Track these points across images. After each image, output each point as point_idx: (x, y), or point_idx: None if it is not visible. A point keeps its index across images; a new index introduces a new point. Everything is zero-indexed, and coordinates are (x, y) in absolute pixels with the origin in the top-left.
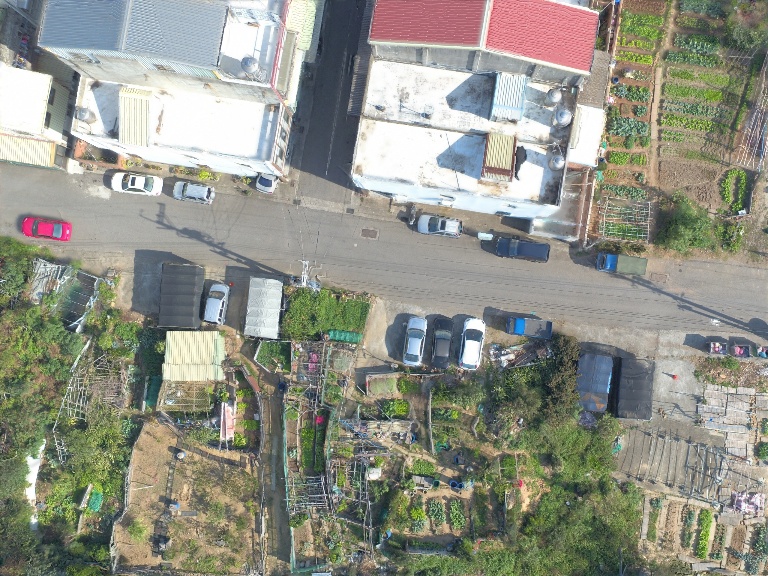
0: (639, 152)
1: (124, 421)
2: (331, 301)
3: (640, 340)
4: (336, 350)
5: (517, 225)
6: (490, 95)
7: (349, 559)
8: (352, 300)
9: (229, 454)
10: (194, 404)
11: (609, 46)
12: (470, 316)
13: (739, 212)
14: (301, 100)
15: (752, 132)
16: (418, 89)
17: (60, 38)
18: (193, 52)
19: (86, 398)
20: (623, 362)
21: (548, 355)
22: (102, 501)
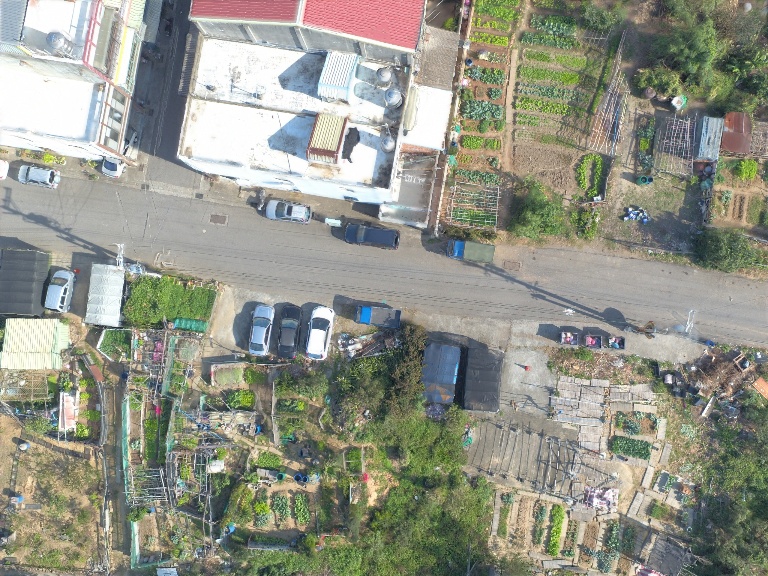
0: (494, 136)
1: None
2: (178, 288)
3: (492, 330)
4: (183, 339)
5: (368, 211)
6: None
7: (194, 554)
8: (199, 288)
9: (73, 445)
10: (32, 393)
11: (464, 27)
12: (319, 304)
13: (594, 198)
14: (151, 82)
15: (605, 115)
16: (250, 68)
17: None
18: None
19: None
20: (469, 352)
21: (395, 345)
22: None
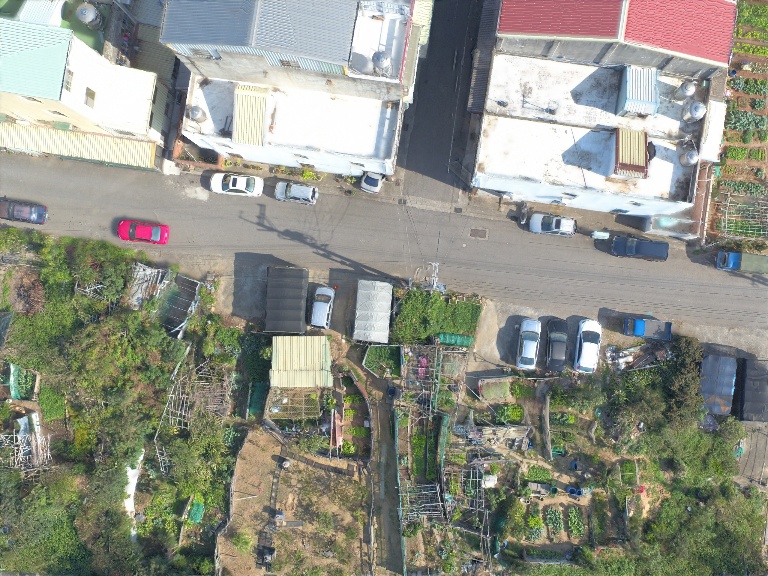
0: (757, 147)
1: (226, 429)
2: (440, 303)
3: (761, 340)
4: (446, 354)
5: (632, 223)
6: (616, 89)
7: (462, 569)
8: (462, 302)
9: (336, 462)
10: (303, 411)
11: None
12: (584, 317)
13: None
14: None
15: None
16: (541, 84)
17: (184, 34)
18: (324, 47)
19: (188, 406)
20: (748, 363)
21: (668, 357)
22: (203, 512)
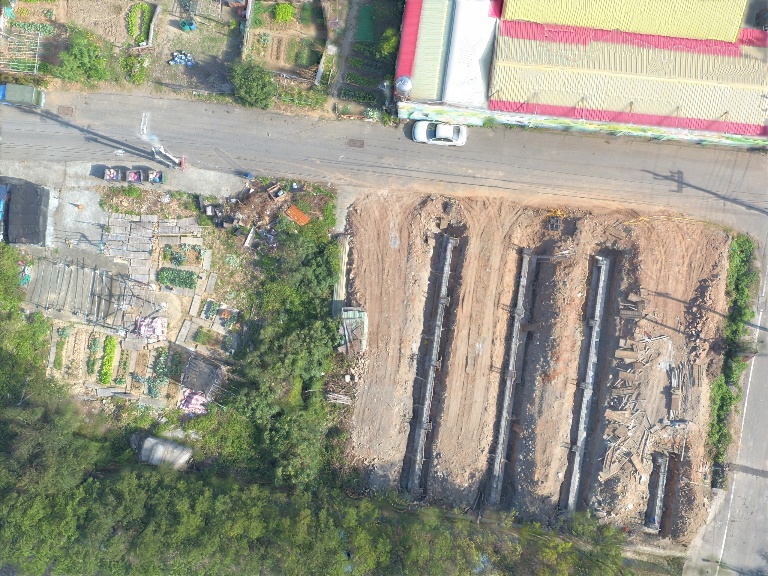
0: None
1: None
2: None
3: (48, 172)
4: None
5: None
6: None
7: None
8: None
9: None
10: None
11: None
12: None
13: (140, 44)
14: None
15: None
16: None
17: None
18: None
19: None
20: (12, 188)
21: None
22: None
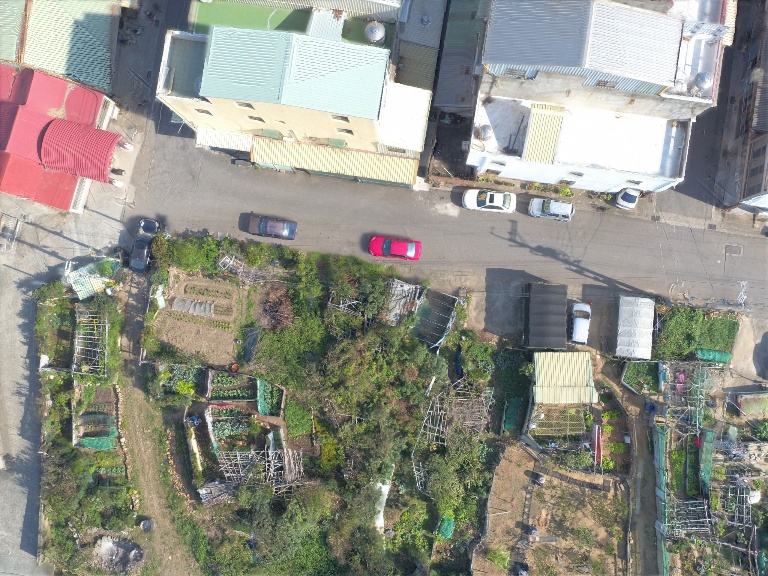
0: None
1: (480, 445)
2: None
3: None
4: None
5: None
6: None
7: None
8: (718, 318)
9: (591, 478)
10: (568, 427)
11: None
12: None
13: None
14: None
15: None
16: None
17: (510, 54)
18: (652, 68)
19: (446, 422)
20: None
21: None
22: (454, 527)
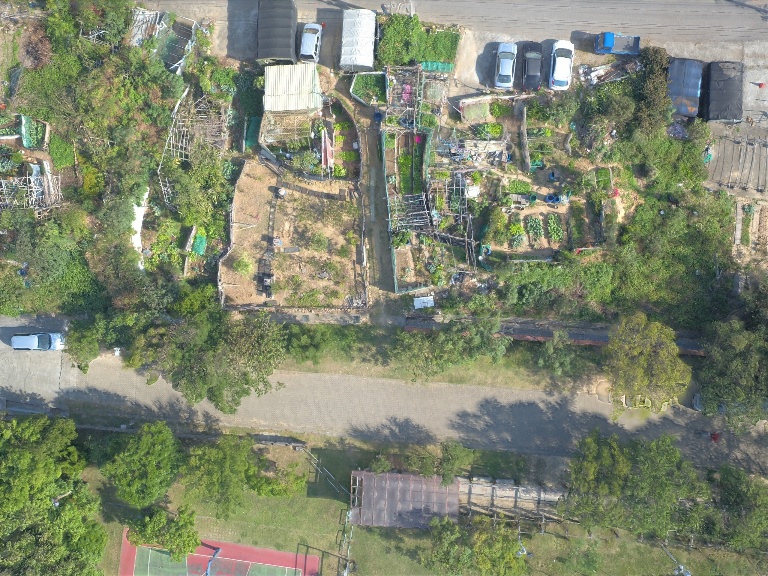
0: None
1: (225, 163)
2: (421, 34)
3: (725, 52)
4: (428, 81)
5: None
6: None
7: (450, 282)
8: (442, 32)
9: (328, 188)
10: (295, 132)
11: None
12: None
13: None
14: None
15: None
16: None
17: None
18: None
19: (189, 139)
20: (712, 66)
21: (637, 67)
22: (206, 245)
